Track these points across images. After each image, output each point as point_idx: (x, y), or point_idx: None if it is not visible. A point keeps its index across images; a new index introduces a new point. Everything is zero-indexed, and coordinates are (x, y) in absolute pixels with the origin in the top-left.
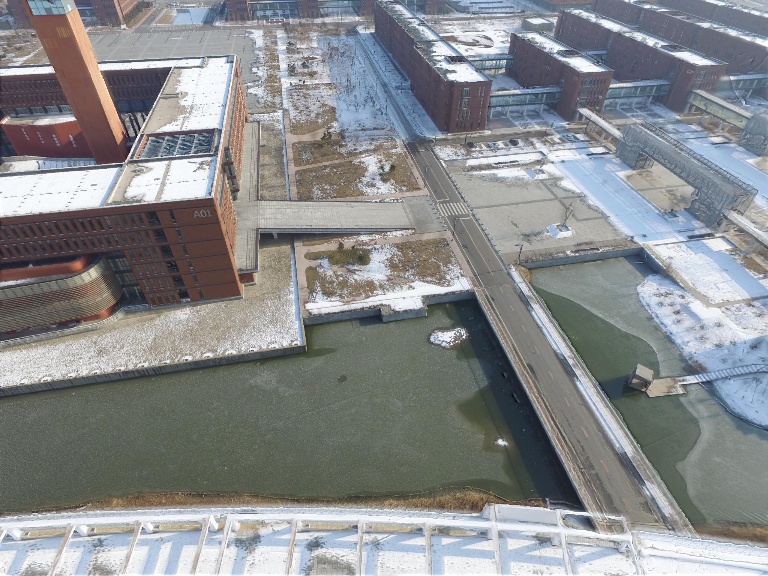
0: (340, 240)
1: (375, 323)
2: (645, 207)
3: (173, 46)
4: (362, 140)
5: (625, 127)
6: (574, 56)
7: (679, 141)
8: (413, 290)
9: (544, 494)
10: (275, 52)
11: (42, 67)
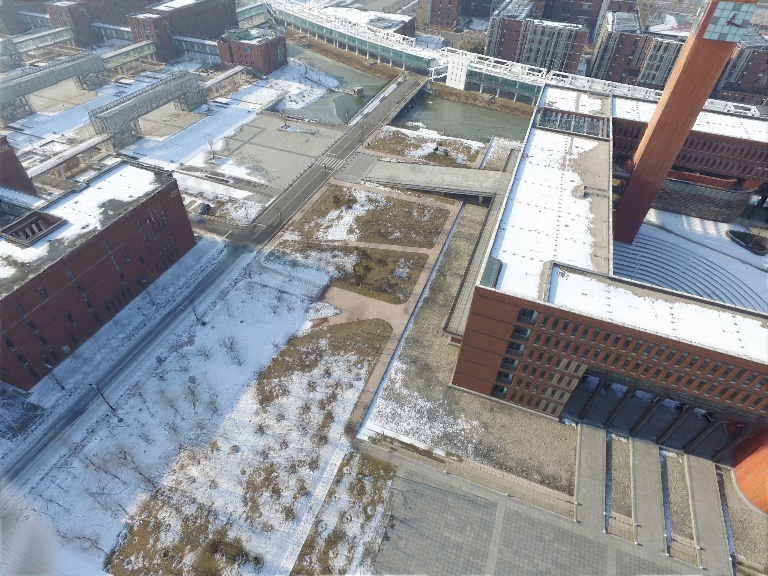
0: None
1: None
2: (208, 120)
3: None
4: (309, 269)
5: (109, 120)
6: None
7: (128, 94)
8: (418, 134)
9: None
10: None
11: None
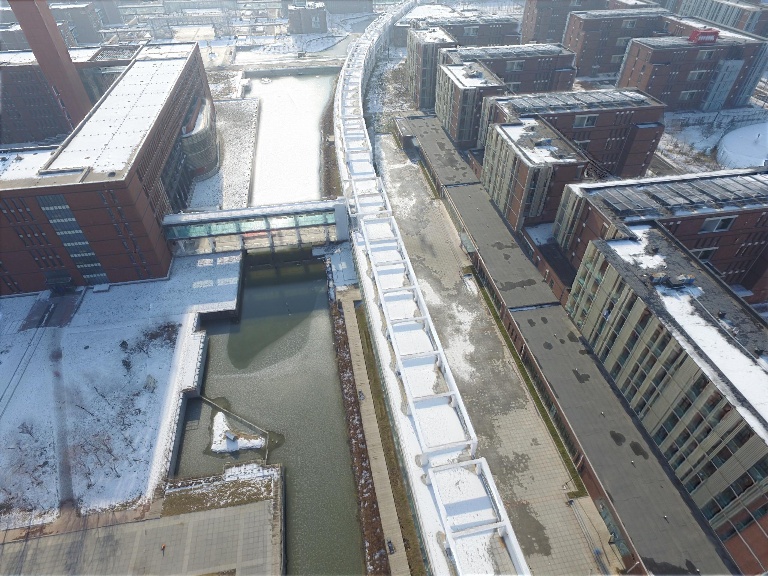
0: None
1: None
2: None
3: None
4: None
5: (148, 20)
6: (50, 6)
7: None
8: (236, 80)
9: (336, 73)
10: None
11: None
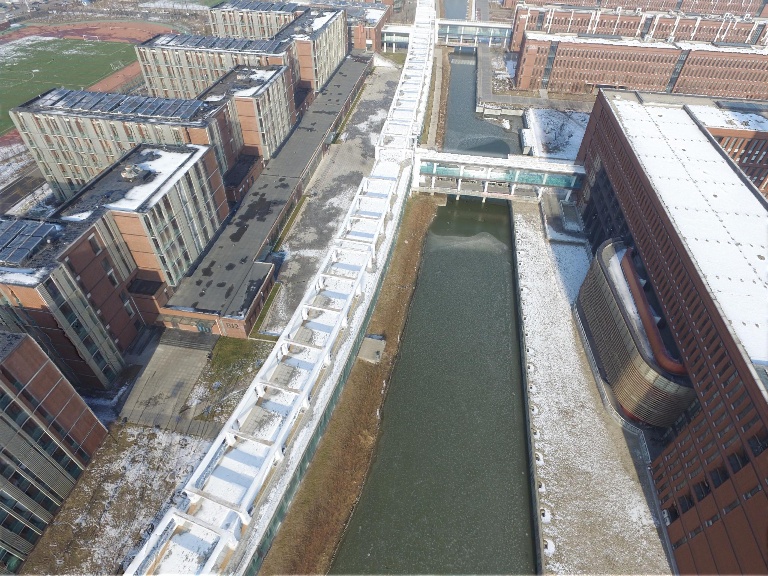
0: None
1: None
2: None
3: None
4: None
5: None
6: None
7: None
8: None
9: None
10: None
11: None
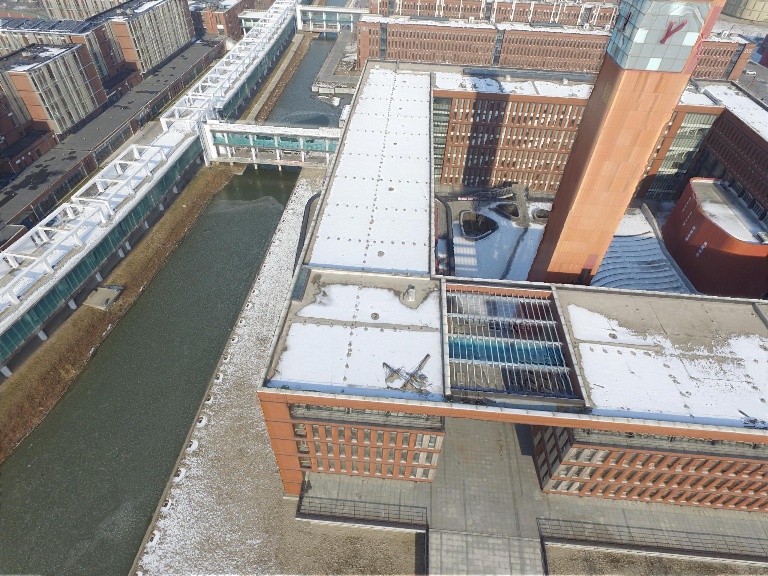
0: None
1: None
2: None
3: None
4: None
5: None
6: None
7: None
8: None
9: None
10: None
11: None
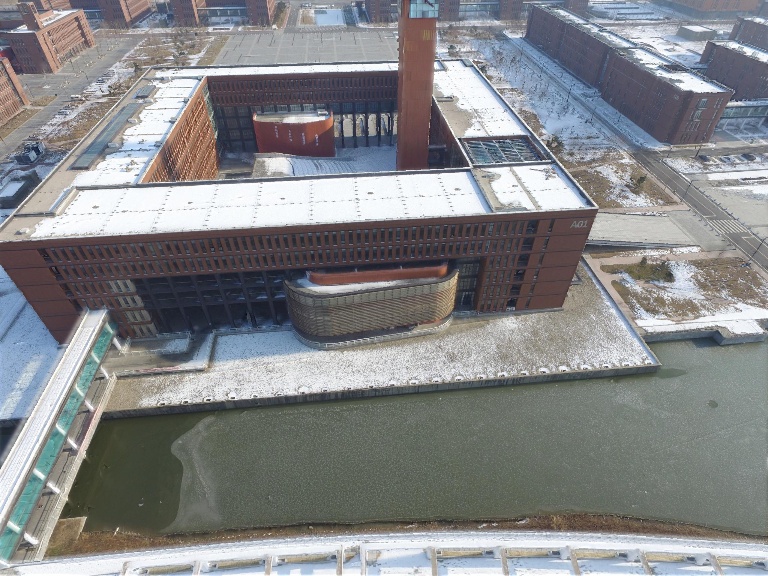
0: (628, 254)
1: (712, 345)
2: None
3: (332, 47)
4: (583, 149)
5: None
6: None
7: None
8: (742, 312)
9: None
10: (439, 55)
11: (289, 66)
